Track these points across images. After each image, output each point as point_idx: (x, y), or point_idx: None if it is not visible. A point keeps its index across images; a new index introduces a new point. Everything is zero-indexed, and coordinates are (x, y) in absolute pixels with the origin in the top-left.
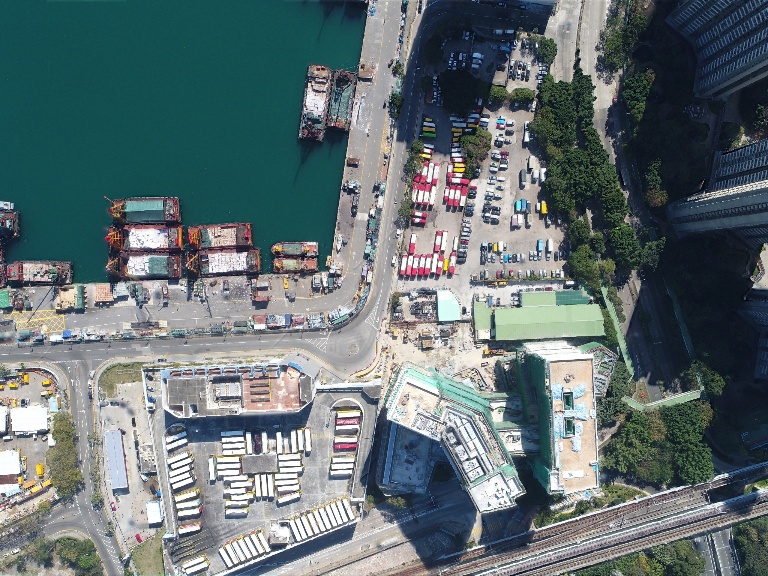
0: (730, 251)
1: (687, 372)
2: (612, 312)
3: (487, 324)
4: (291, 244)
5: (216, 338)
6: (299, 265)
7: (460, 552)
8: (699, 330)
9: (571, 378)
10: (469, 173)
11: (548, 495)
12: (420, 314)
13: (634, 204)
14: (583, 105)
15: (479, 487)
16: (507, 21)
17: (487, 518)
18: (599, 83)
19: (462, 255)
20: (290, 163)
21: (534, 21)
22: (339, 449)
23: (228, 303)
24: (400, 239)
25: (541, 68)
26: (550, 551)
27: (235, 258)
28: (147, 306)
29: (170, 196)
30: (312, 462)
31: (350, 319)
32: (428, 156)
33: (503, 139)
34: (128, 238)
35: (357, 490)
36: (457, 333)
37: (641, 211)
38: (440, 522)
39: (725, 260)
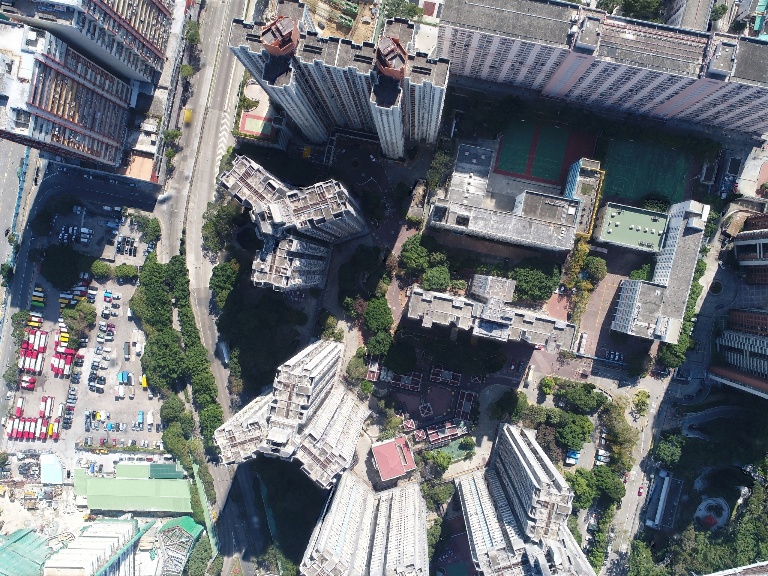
0: None
1: (264, 557)
2: (201, 490)
3: (86, 490)
4: None
5: None
6: None
7: None
8: (280, 516)
9: None
10: (72, 344)
11: None
12: (27, 474)
13: None
14: (177, 287)
15: None
16: (118, 197)
17: None
18: (205, 262)
19: (66, 421)
20: None
21: (144, 199)
22: None
23: None
24: (11, 401)
25: (148, 245)
26: None
27: None
28: None
29: None
30: None
31: None
32: (36, 324)
33: (108, 312)
34: None
35: None
36: (61, 495)
37: None
38: None
39: None
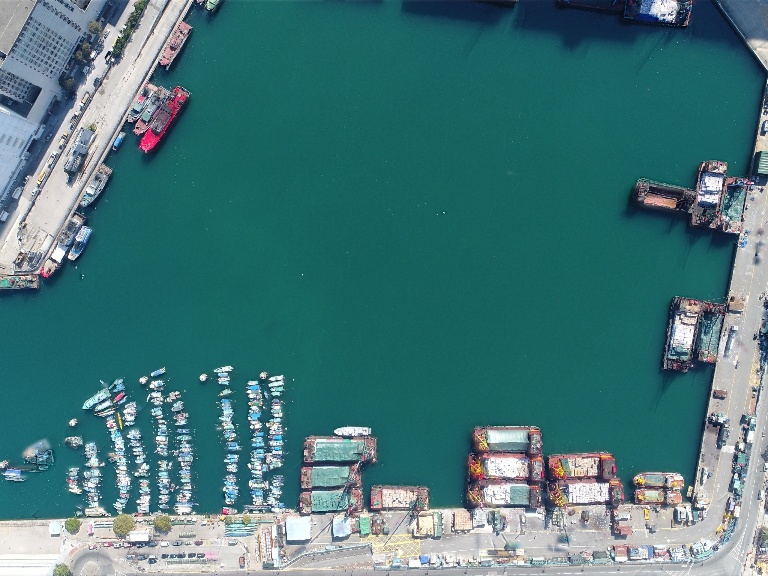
0: None
1: None
2: None
3: None
4: (653, 475)
5: (574, 568)
6: (661, 497)
7: None
8: None
9: None
10: None
11: None
12: None
13: None
14: None
15: None
16: None
17: None
18: None
19: None
20: (651, 392)
21: None
22: None
23: (586, 532)
24: (767, 473)
25: None
26: None
27: (596, 489)
28: (504, 533)
29: (530, 425)
30: None
31: (713, 552)
32: None
33: None
34: (487, 466)
35: None
36: None
37: None
38: None
39: None
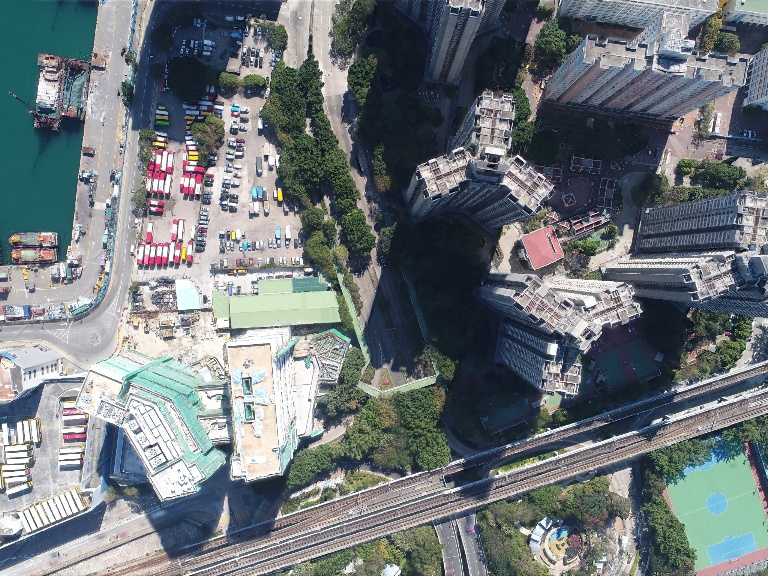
0: (460, 236)
1: (420, 357)
2: (348, 298)
3: (226, 312)
4: (29, 235)
5: None
6: None
7: (202, 542)
8: (432, 315)
9: (250, 363)
10: (202, 161)
11: (281, 483)
12: (161, 303)
13: (372, 190)
14: (311, 91)
15: (162, 474)
16: (239, 8)
17: (234, 507)
18: (334, 69)
19: (200, 243)
20: (28, 153)
21: (266, 7)
22: (69, 440)
23: None
24: (139, 228)
25: (274, 55)
26: (291, 539)
27: None
28: None
29: None
30: (43, 453)
31: (91, 309)
32: (162, 144)
33: (237, 126)
34: None
35: (94, 481)
36: (199, 322)
37: (379, 197)
38: (188, 512)
39: (458, 245)
